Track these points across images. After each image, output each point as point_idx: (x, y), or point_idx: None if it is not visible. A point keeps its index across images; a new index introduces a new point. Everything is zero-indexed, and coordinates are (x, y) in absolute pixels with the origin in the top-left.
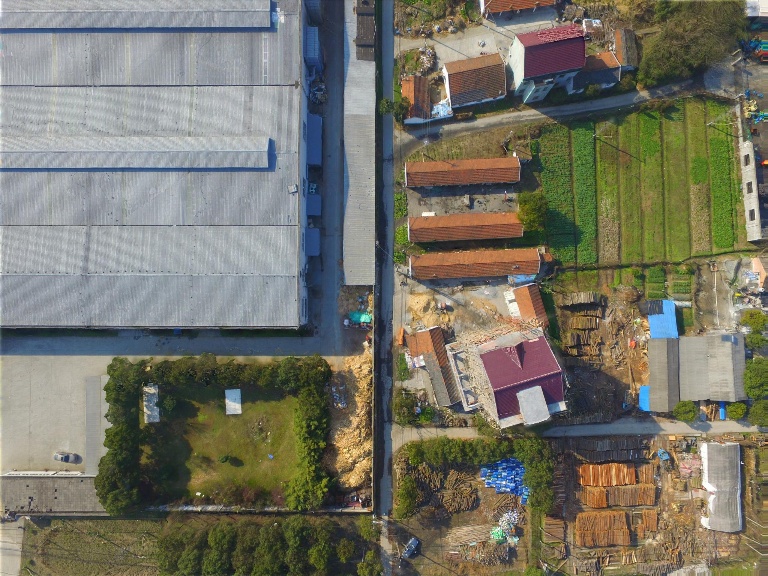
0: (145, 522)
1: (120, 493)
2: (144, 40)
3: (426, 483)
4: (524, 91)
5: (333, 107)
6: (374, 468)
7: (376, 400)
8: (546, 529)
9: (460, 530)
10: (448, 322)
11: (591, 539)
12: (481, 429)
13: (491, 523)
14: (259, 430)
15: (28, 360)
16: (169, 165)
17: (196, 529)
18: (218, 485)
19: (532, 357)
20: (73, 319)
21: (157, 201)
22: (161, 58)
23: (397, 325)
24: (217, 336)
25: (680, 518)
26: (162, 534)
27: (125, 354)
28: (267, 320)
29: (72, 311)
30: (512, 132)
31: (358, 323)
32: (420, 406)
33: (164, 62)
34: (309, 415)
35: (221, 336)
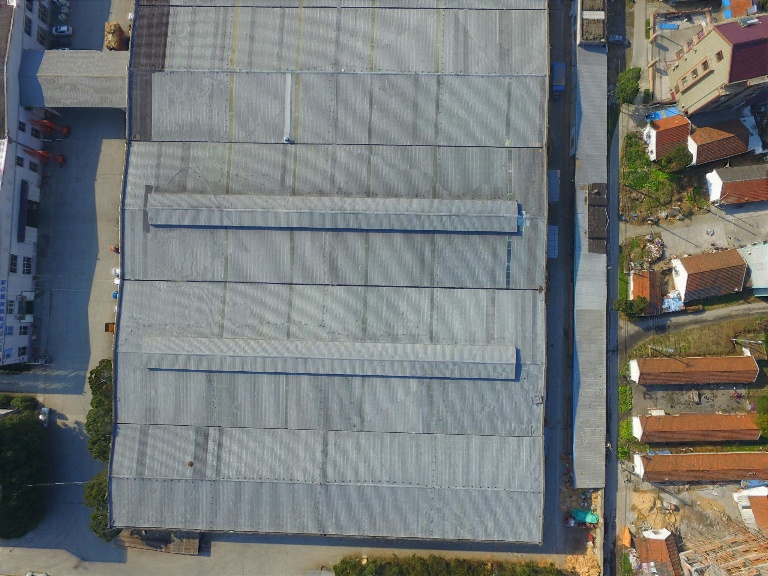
0: None
1: None
2: (384, 240)
3: None
4: (761, 288)
5: (556, 294)
6: None
7: None
8: None
9: None
10: (674, 522)
11: None
12: None
13: None
14: None
15: (241, 547)
16: (413, 374)
17: None
18: None
19: None
20: (309, 527)
21: (397, 408)
22: (401, 259)
23: (621, 524)
24: None
25: None
26: None
27: (341, 545)
28: (509, 534)
29: (308, 519)
30: None
31: (583, 522)
32: None
33: (404, 263)
34: None
35: None
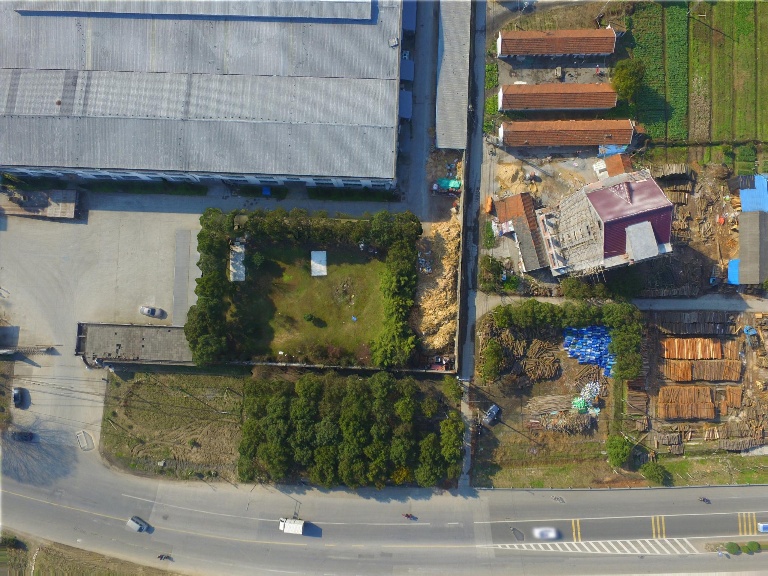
0: (227, 378)
1: (211, 337)
2: None
3: (509, 350)
4: None
5: None
6: (459, 330)
7: (463, 264)
8: (628, 401)
9: (541, 399)
10: (536, 192)
11: (675, 410)
12: (571, 291)
13: (572, 394)
14: (343, 292)
15: (117, 216)
16: (273, 14)
17: None
18: (301, 345)
19: (641, 194)
20: (171, 164)
21: (258, 51)
22: None
23: (484, 194)
24: (305, 198)
25: (765, 396)
26: (250, 380)
27: None
28: (363, 171)
29: (171, 156)
30: (606, 6)
31: (446, 189)
32: (505, 274)
33: None
34: (401, 268)
35: (309, 198)
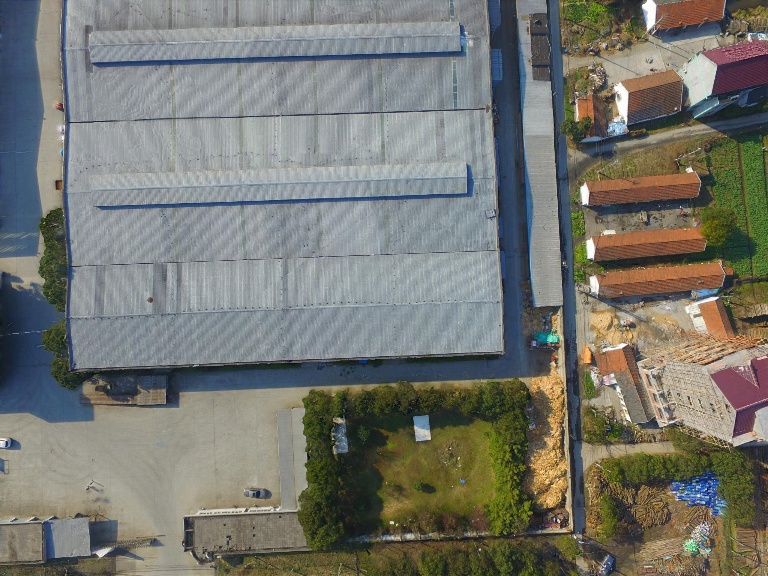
0: (340, 554)
1: (329, 528)
2: (331, 68)
3: (619, 500)
4: (698, 107)
5: (506, 128)
6: (571, 488)
7: (569, 420)
8: (738, 539)
9: (654, 544)
10: (631, 339)
11: None
12: (681, 445)
13: (683, 536)
14: (449, 455)
15: (210, 396)
16: (367, 194)
17: (395, 559)
18: (411, 513)
19: (767, 375)
20: (274, 354)
21: (354, 231)
22: (349, 85)
23: (581, 344)
24: (402, 363)
25: None
26: (373, 567)
27: (310, 385)
28: (471, 346)
29: (273, 346)
30: None
31: (544, 344)
32: (609, 423)
33: (352, 89)
34: (515, 440)
35: (406, 363)
